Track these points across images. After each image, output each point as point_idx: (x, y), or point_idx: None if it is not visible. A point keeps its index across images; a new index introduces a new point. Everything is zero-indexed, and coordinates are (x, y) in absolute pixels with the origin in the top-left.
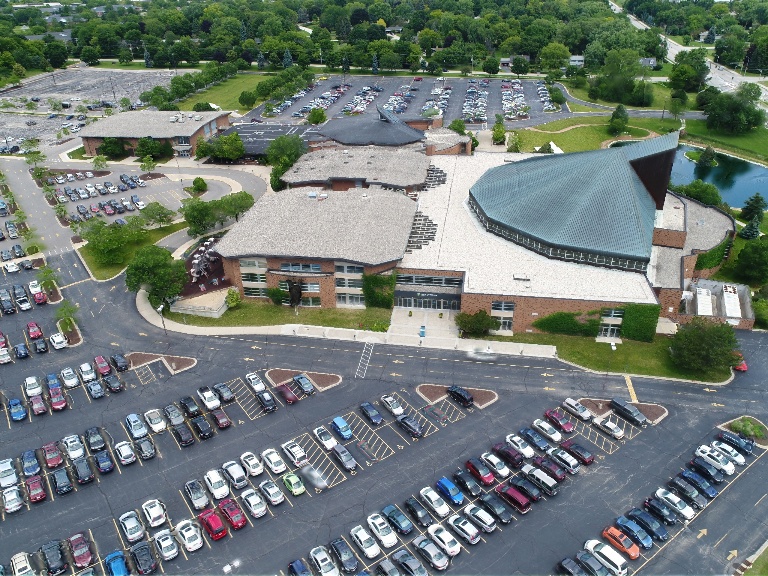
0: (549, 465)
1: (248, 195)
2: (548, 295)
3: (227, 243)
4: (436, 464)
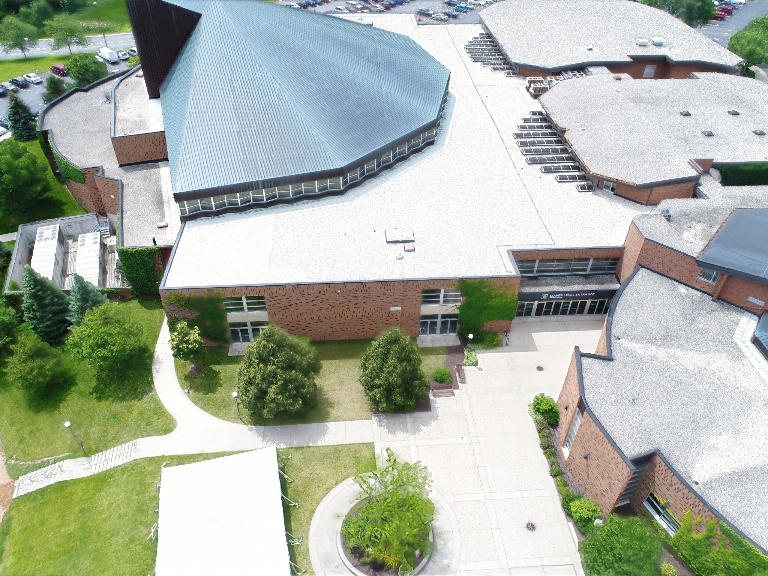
0: (350, 6)
1: (745, 40)
2: (344, 15)
3: (658, 11)
4: (406, 8)
